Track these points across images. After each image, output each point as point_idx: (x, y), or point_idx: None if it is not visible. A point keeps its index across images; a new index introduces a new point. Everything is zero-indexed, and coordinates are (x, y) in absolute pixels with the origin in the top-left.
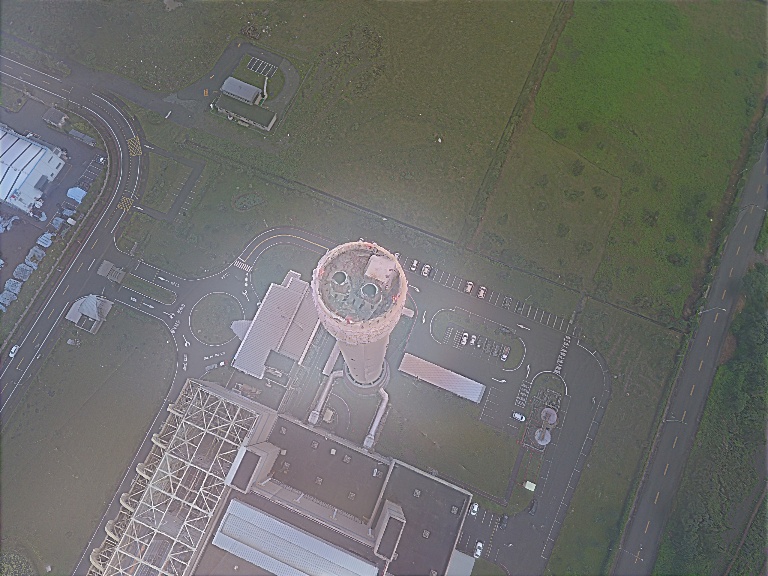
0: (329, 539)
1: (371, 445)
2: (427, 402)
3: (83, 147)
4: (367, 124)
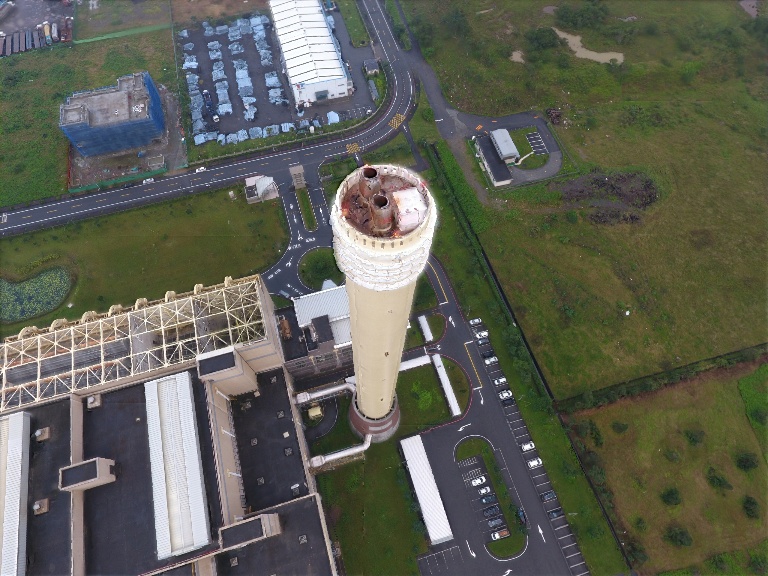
0: (207, 479)
1: (316, 465)
2: (394, 492)
3: (367, 96)
4: (577, 246)
